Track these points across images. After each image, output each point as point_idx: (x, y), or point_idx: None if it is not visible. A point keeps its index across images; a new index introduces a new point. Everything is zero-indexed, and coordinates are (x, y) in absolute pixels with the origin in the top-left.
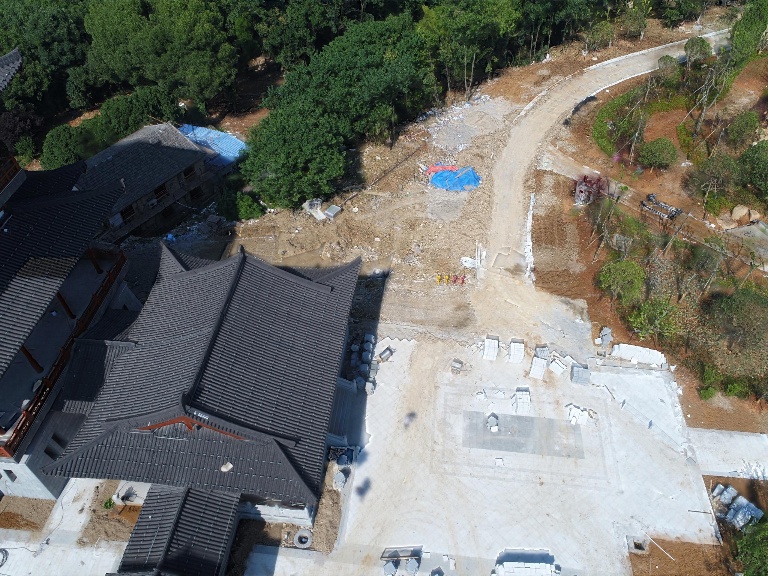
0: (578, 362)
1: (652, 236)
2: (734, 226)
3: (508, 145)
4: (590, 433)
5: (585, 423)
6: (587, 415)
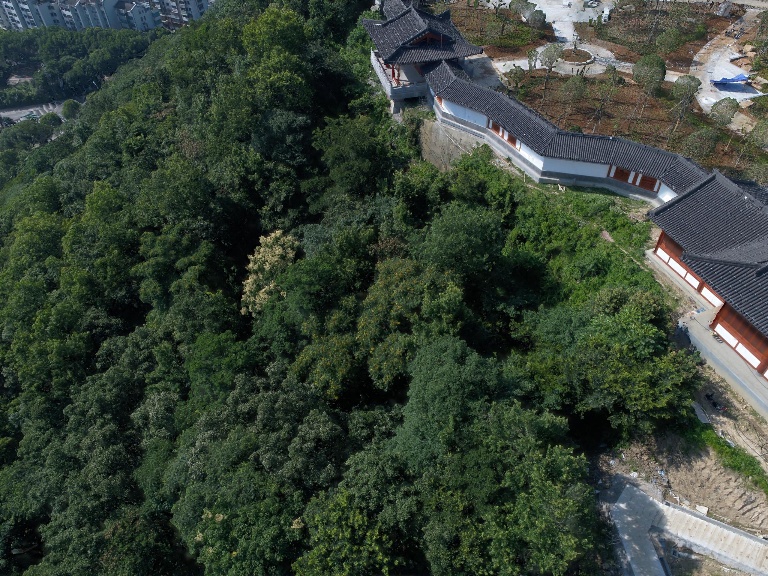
0: (595, 7)
1: (700, 25)
2: (735, 50)
3: (764, 2)
4: (559, 6)
5: (563, 4)
6: (567, 4)
